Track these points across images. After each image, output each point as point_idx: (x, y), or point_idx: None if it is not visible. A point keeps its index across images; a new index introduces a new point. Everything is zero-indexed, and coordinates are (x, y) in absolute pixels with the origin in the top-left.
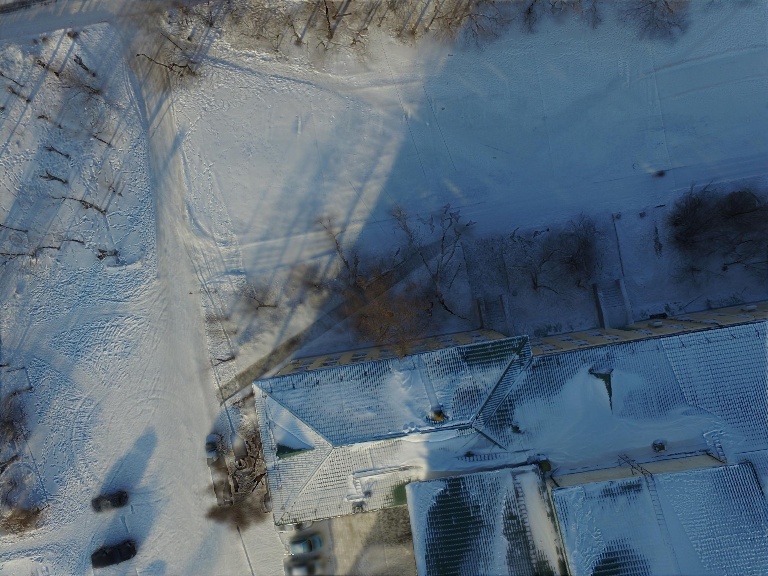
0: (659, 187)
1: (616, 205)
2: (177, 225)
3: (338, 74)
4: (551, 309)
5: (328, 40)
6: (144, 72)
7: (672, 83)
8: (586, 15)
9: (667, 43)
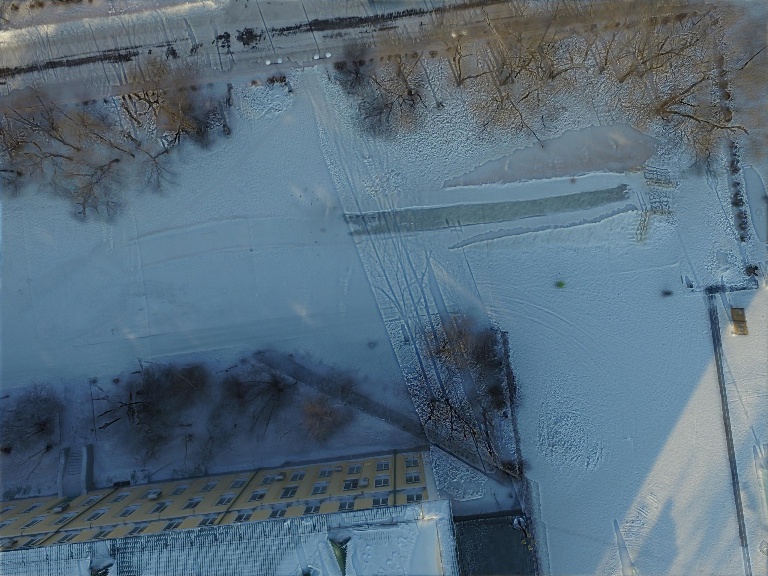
0: (136, 353)
1: (93, 369)
2: None
3: None
4: (23, 471)
5: None
6: None
7: (154, 250)
8: (44, 189)
9: (150, 211)
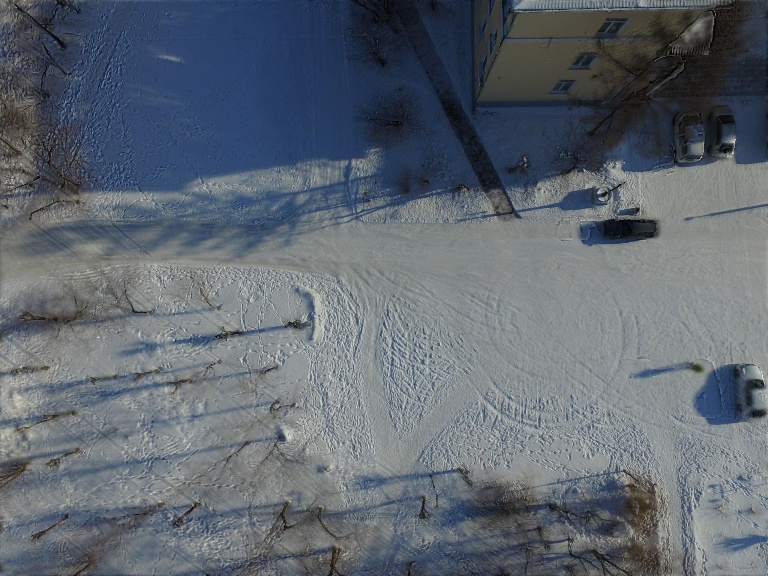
0: None
1: None
2: (272, 240)
3: (113, 1)
4: None
5: (68, 7)
6: (65, 253)
7: None
8: None
9: None
